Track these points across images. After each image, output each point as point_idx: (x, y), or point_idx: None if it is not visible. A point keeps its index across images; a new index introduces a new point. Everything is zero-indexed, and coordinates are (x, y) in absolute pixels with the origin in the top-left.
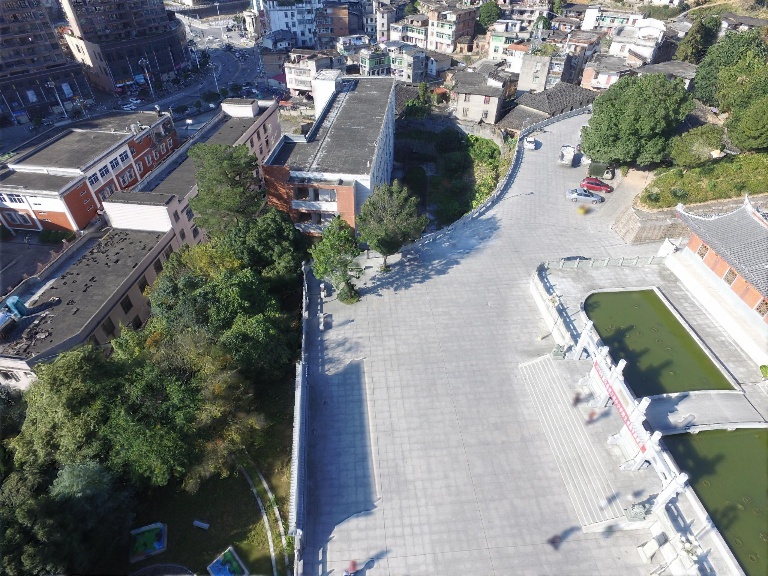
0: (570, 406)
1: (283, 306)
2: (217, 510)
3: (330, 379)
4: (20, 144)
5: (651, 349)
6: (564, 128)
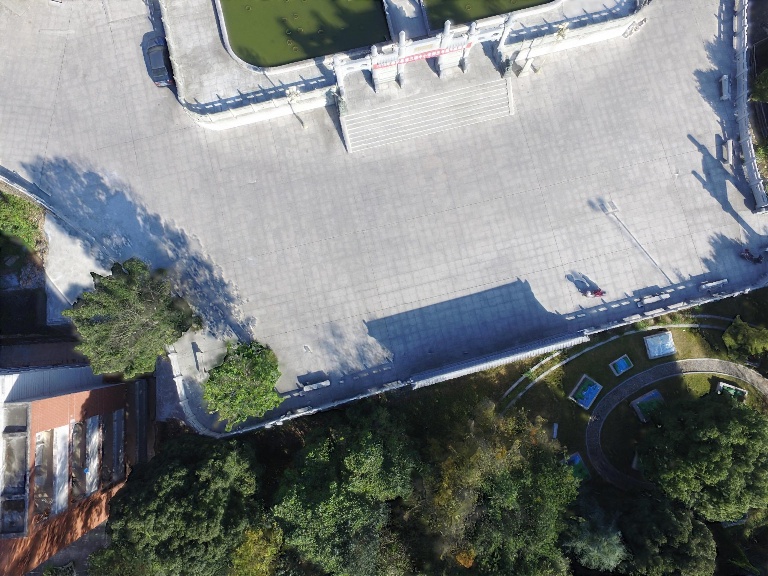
0: (405, 105)
1: (261, 455)
2: None
3: (400, 354)
4: None
5: (318, 10)
6: None
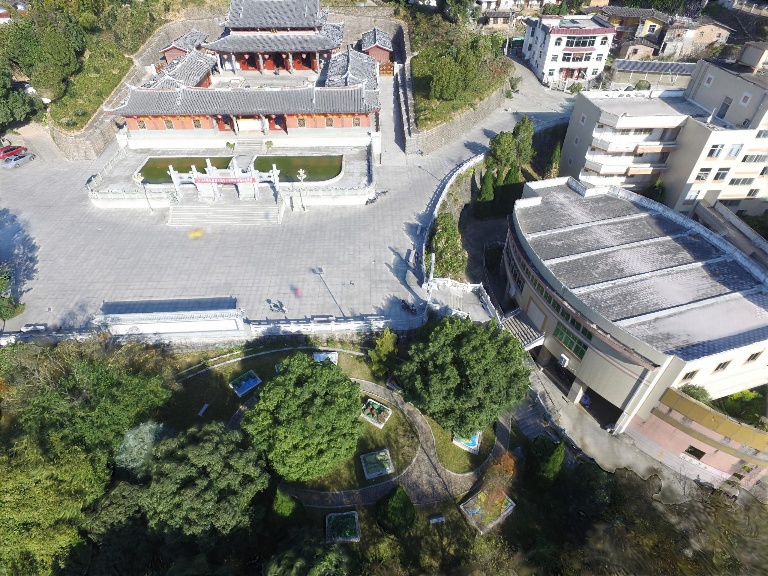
0: (212, 207)
1: None
2: (195, 402)
3: None
4: None
5: None
6: None
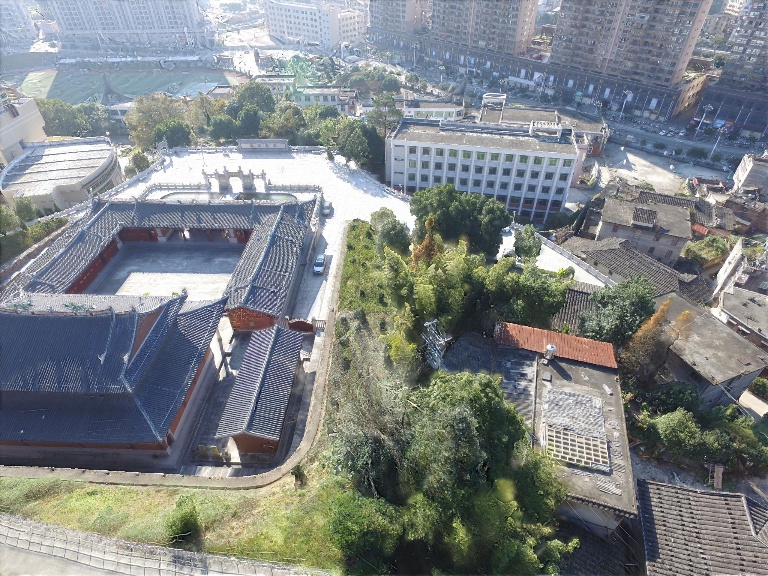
0: None
1: None
2: None
3: None
4: (536, 105)
5: None
6: (546, 256)
